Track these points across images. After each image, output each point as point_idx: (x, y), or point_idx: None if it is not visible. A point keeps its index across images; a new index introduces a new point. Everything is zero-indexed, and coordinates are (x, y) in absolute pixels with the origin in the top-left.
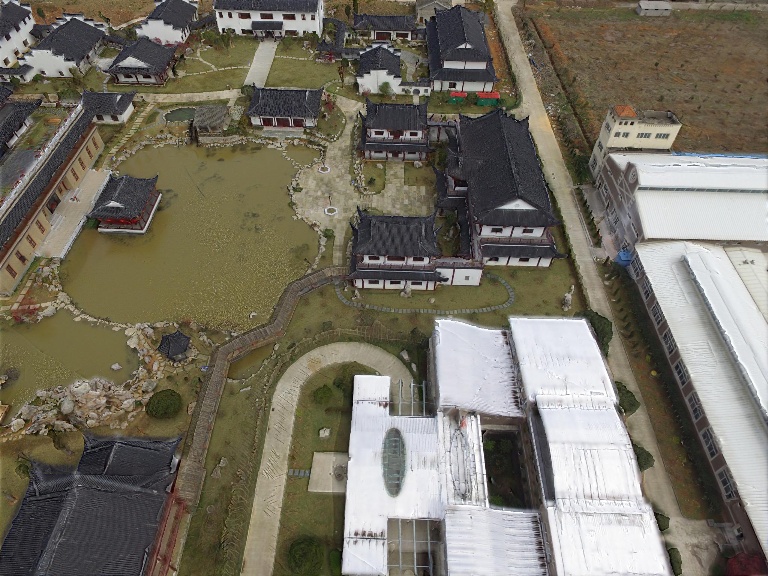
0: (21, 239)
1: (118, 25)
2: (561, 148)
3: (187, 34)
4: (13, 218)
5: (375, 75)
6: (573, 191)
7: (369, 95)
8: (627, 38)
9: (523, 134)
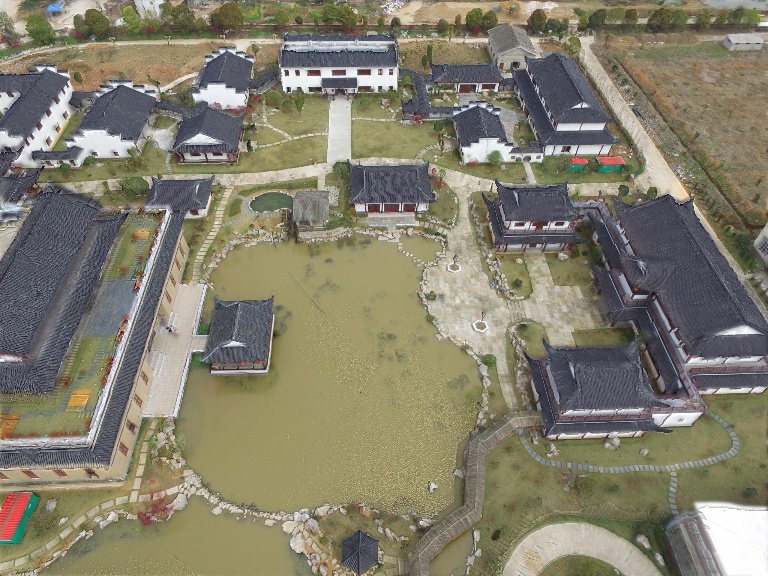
0: (130, 404)
1: (164, 85)
2: (711, 224)
3: (247, 95)
4: (123, 383)
5: (485, 144)
6: (748, 283)
7: (475, 165)
8: (727, 79)
9: (694, 222)
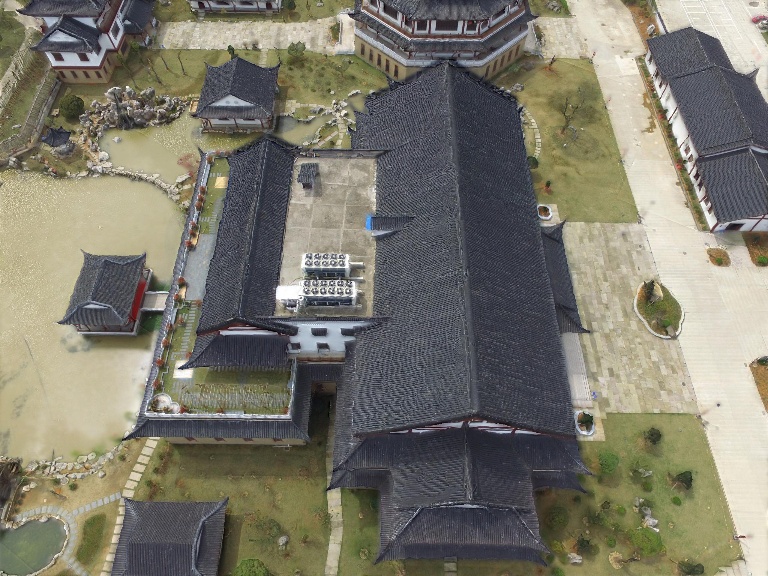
0: None
1: None
2: None
3: None
4: None
5: None
6: None
7: None
8: None
9: None
